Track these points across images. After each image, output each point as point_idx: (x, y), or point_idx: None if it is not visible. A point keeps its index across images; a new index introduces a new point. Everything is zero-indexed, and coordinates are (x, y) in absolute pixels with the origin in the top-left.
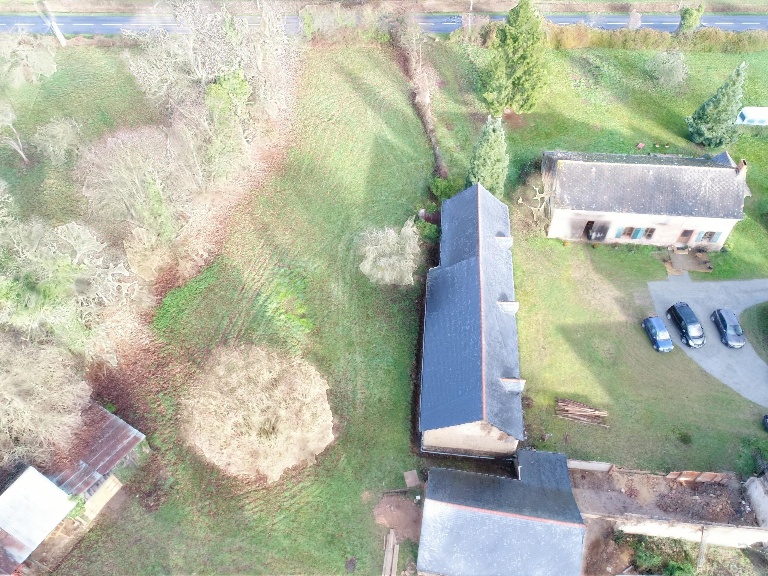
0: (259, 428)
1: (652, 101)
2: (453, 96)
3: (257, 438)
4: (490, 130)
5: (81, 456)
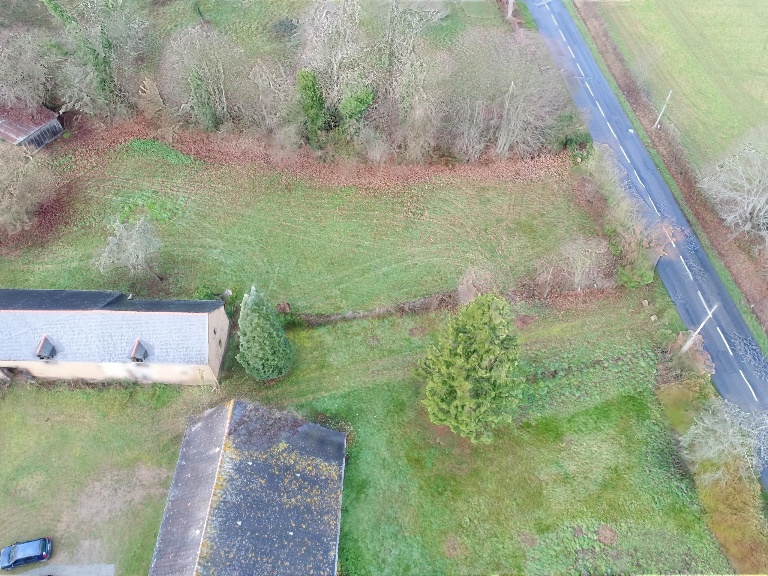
0: None
1: None
2: None
3: None
4: (244, 297)
5: (8, 120)
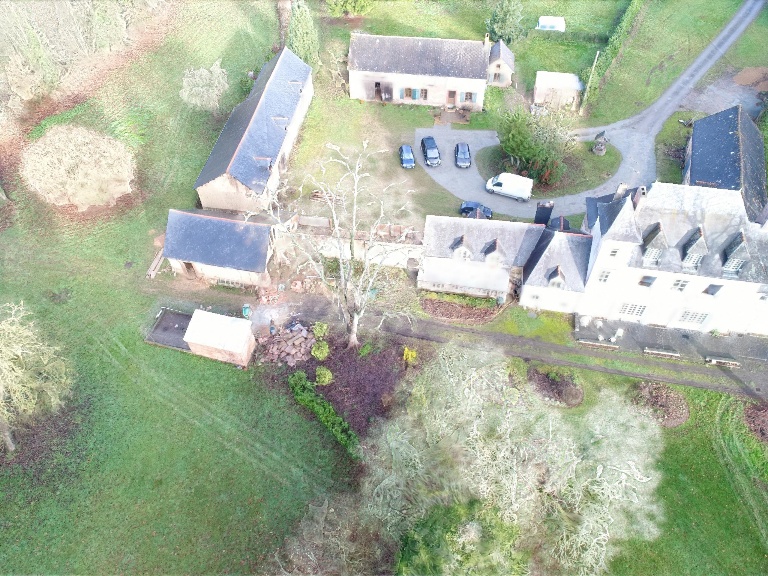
0: (68, 167)
1: (475, 14)
2: (312, 5)
3: (66, 172)
4: (295, 6)
5: None
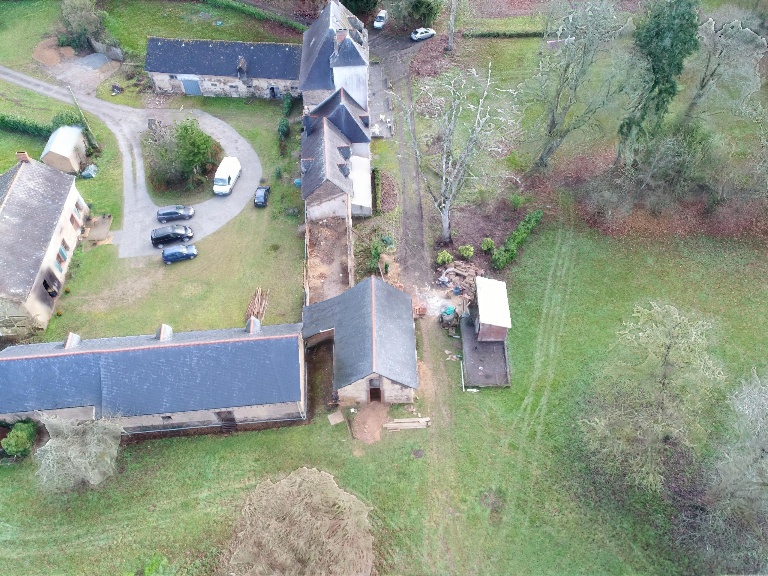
0: None
1: None
2: None
3: None
4: None
5: None
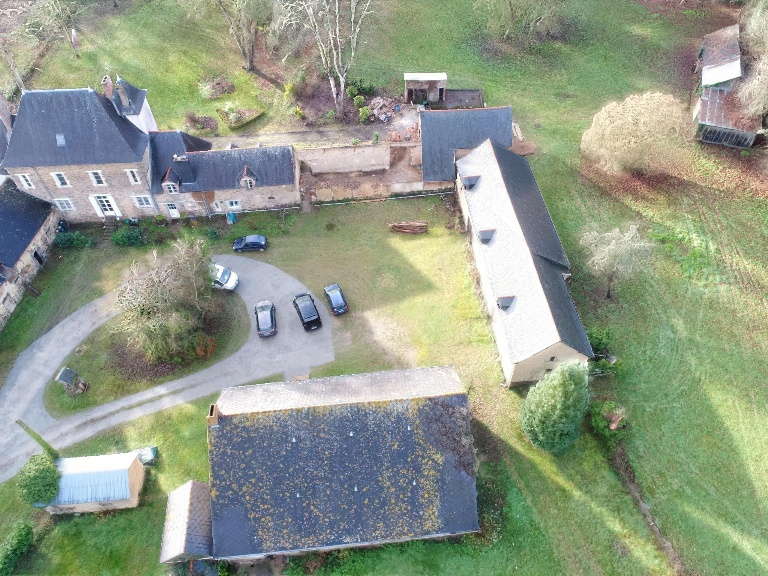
0: None
1: None
2: None
3: None
4: None
5: (725, 104)
